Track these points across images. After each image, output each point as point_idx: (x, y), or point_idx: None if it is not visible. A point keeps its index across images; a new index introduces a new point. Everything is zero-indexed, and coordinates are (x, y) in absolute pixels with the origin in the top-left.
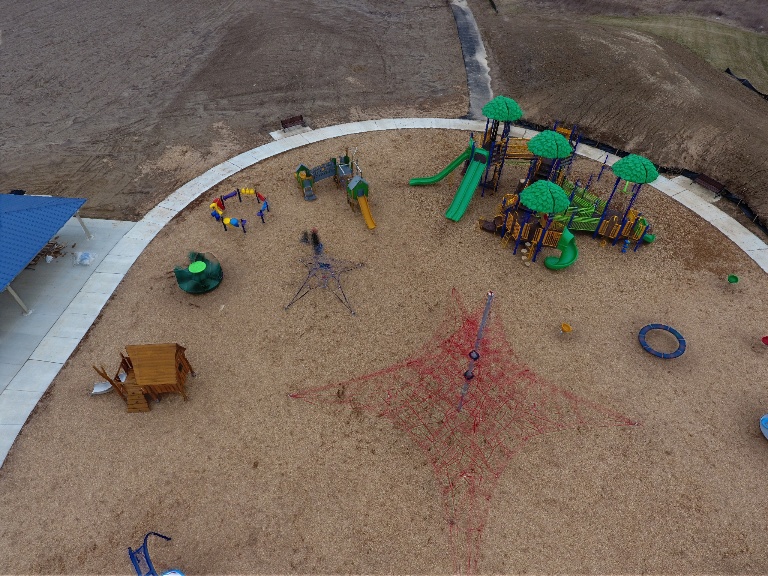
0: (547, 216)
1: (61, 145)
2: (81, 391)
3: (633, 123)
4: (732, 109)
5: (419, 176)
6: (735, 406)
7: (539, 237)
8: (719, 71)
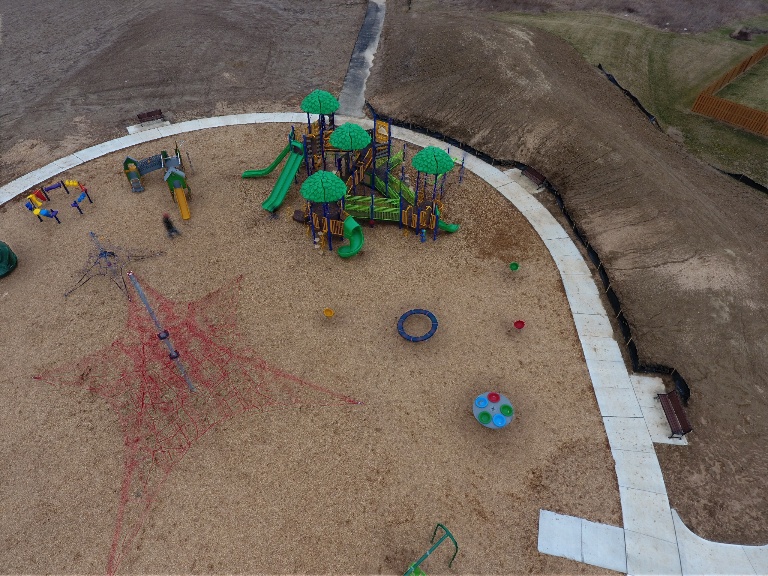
0: (340, 206)
1: None
2: None
3: (483, 117)
4: (576, 103)
5: (257, 169)
6: (463, 386)
7: (327, 226)
8: (591, 67)
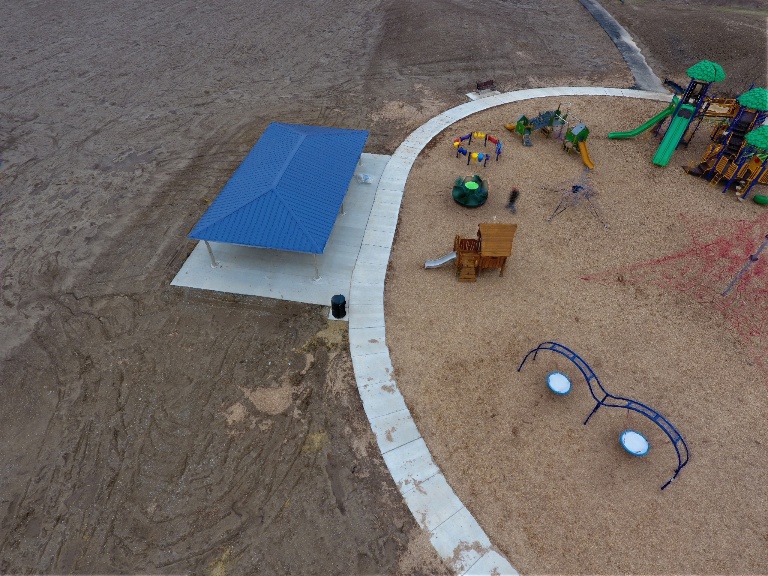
0: None
1: (291, 98)
2: (415, 266)
3: None
4: None
5: None
6: None
7: (756, 175)
8: None
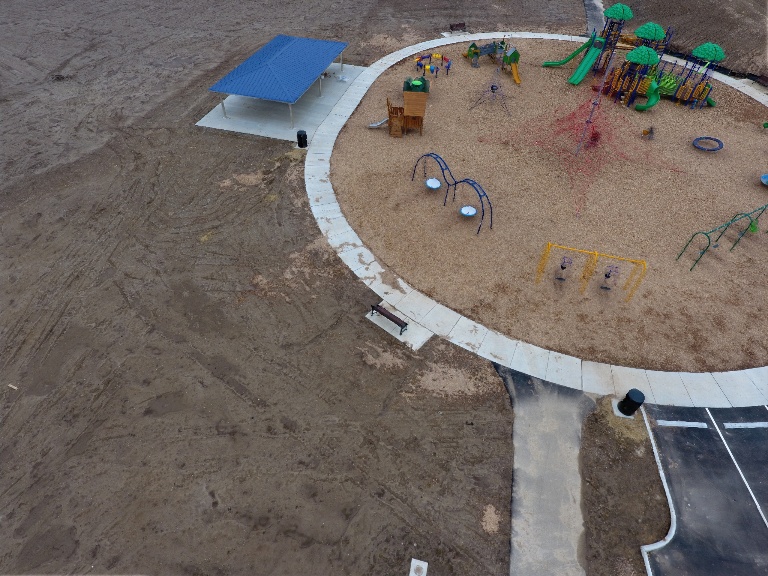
0: None
1: (302, 30)
2: (362, 127)
3: None
4: None
5: None
6: (748, 174)
7: (635, 86)
8: None
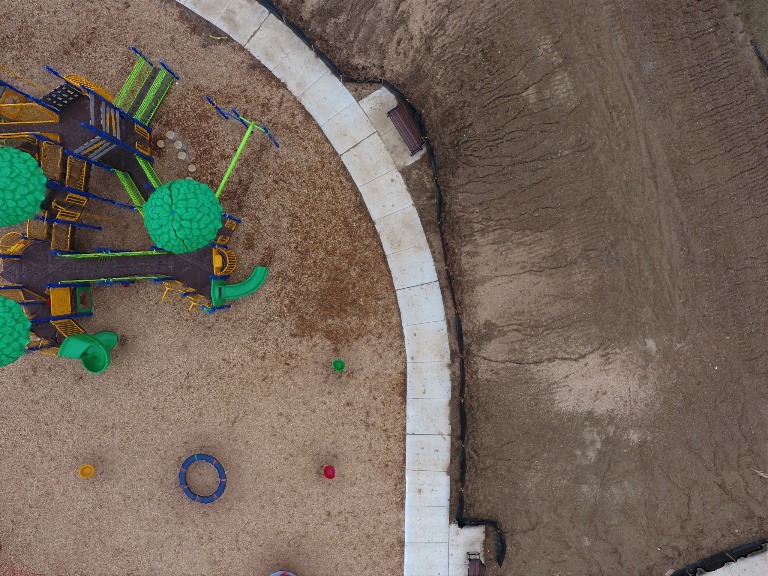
0: None
1: None
2: None
3: None
4: None
5: None
6: (259, 552)
7: None
8: None
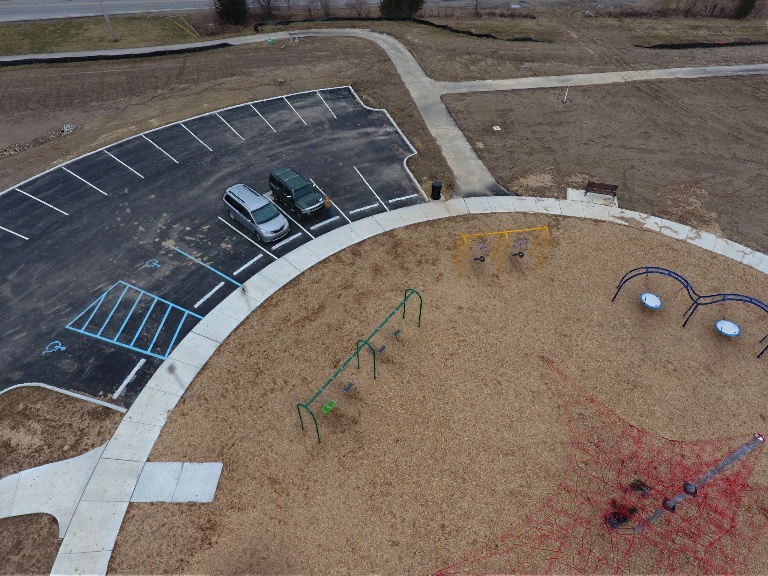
0: None
1: None
2: None
3: None
4: None
5: None
6: None
7: None
8: None
